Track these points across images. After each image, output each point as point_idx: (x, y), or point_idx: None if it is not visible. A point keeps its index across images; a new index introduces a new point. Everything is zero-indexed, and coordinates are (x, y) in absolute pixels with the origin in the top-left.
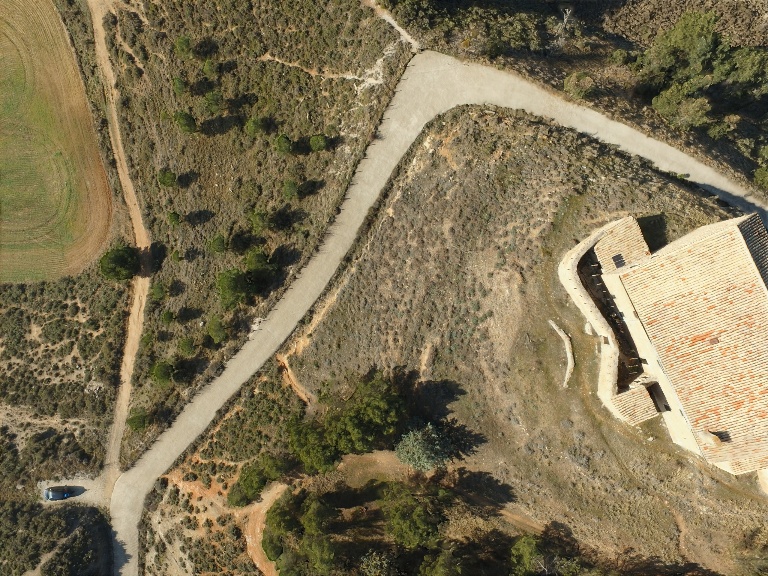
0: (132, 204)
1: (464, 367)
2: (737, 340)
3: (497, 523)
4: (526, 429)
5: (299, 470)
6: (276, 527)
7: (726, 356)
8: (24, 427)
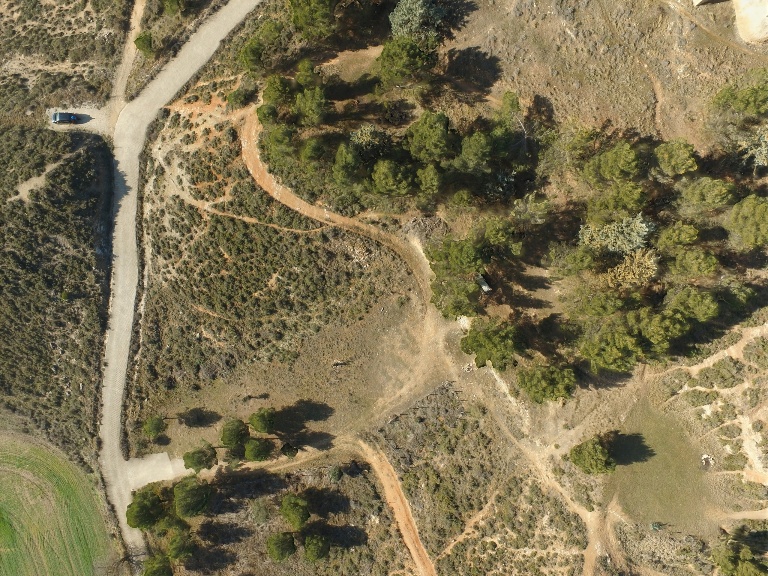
0: None
1: None
2: None
3: (482, 109)
4: None
5: (296, 69)
6: (271, 77)
7: None
8: (36, 73)
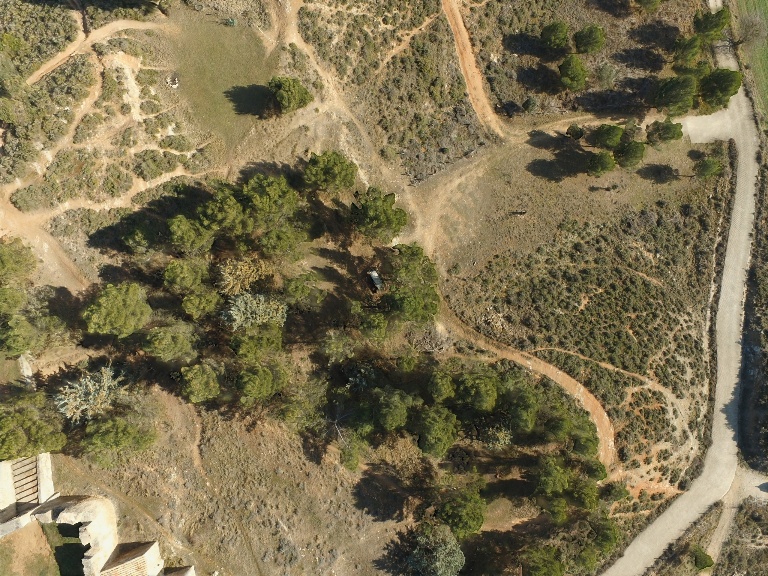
0: None
1: None
2: None
3: (373, 456)
4: None
5: None
6: None
7: None
8: None
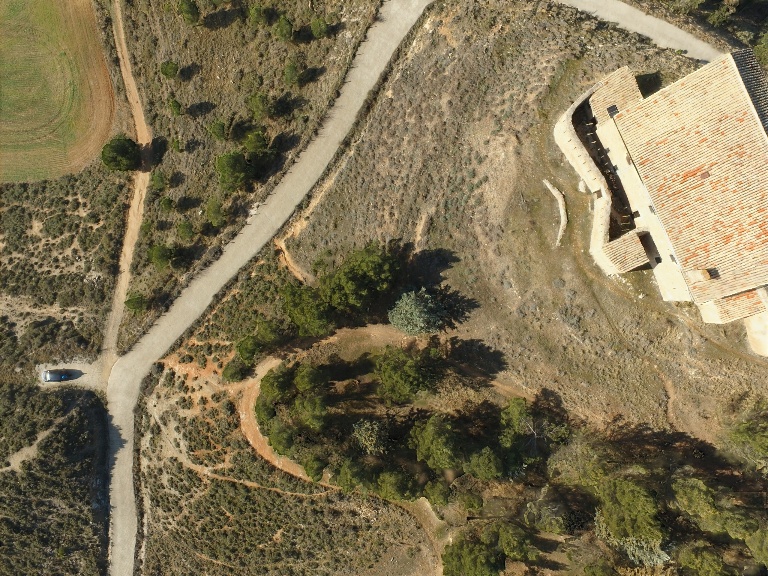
0: (134, 102)
1: (458, 235)
2: (728, 171)
3: (488, 394)
4: (518, 292)
5: (293, 345)
6: (269, 386)
7: (716, 190)
8: (23, 316)
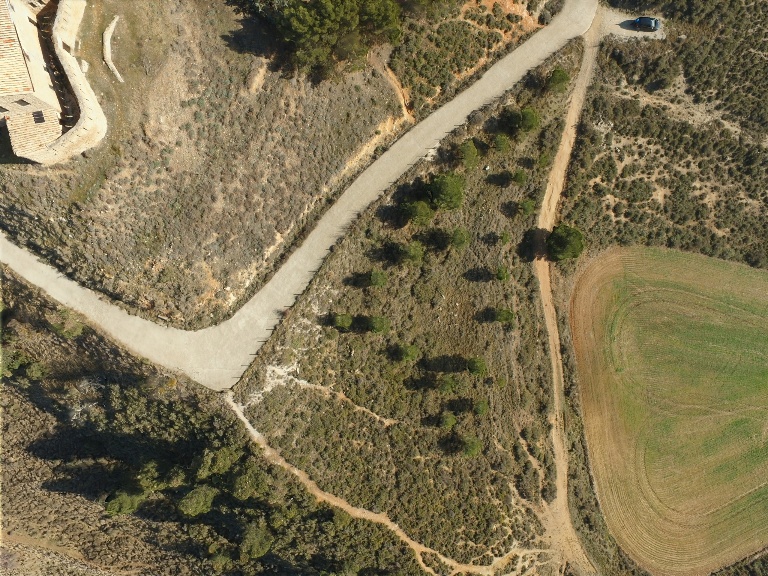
0: (549, 306)
1: (220, 61)
2: None
3: None
4: None
5: None
6: None
7: None
8: (677, 99)
